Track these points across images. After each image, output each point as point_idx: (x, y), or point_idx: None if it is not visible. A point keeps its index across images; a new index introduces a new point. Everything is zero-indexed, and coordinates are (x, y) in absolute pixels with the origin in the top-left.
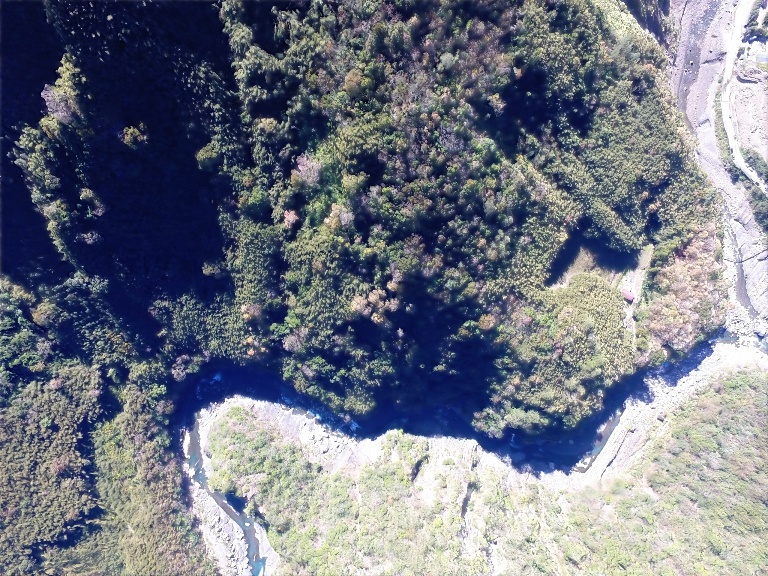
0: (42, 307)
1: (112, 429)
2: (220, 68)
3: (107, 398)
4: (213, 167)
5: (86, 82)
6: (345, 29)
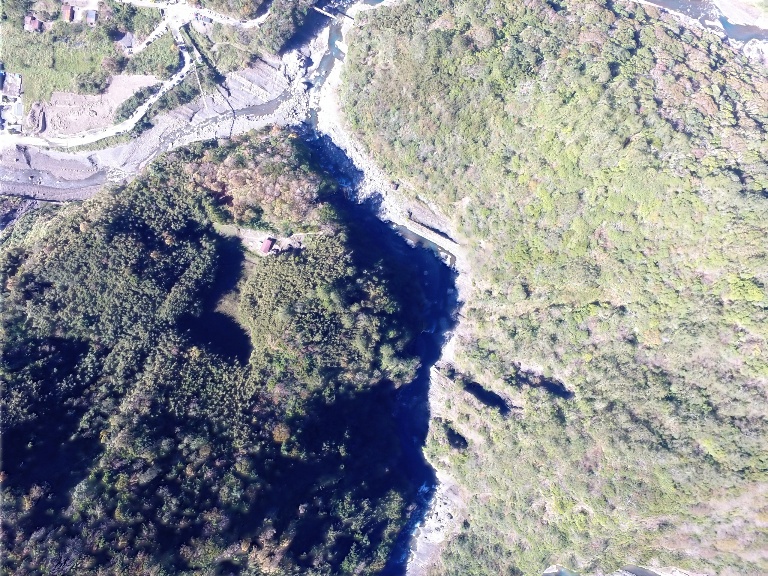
0: None
1: None
2: None
3: None
4: None
5: None
6: None
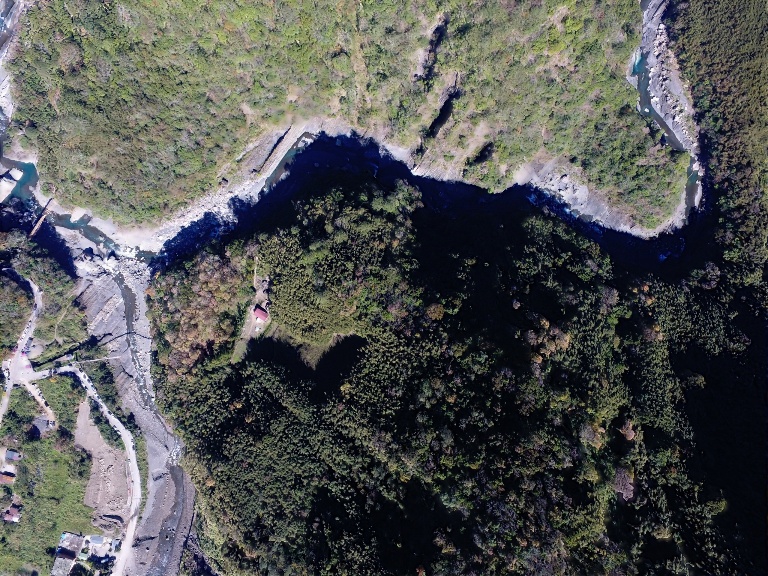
0: None
1: None
2: None
3: None
4: (707, 490)
5: None
6: None
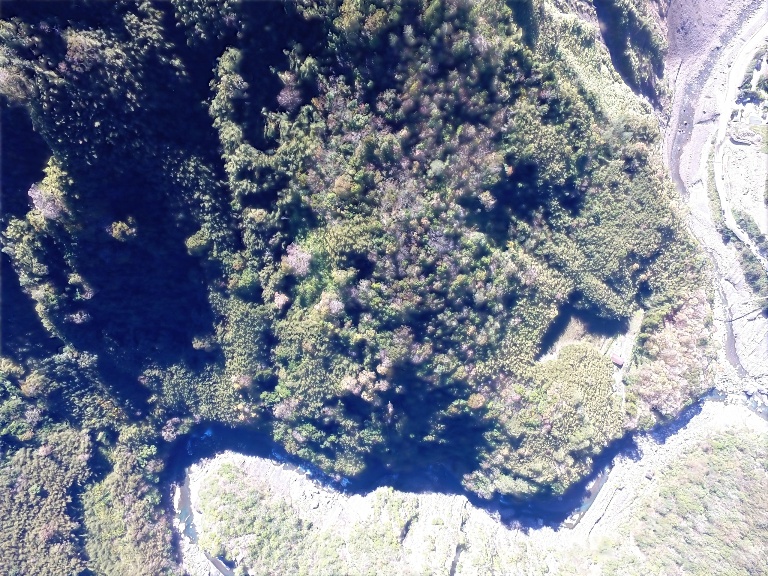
0: (31, 379)
1: (102, 490)
2: (210, 160)
3: (97, 459)
4: (203, 252)
5: (73, 184)
6: (335, 137)
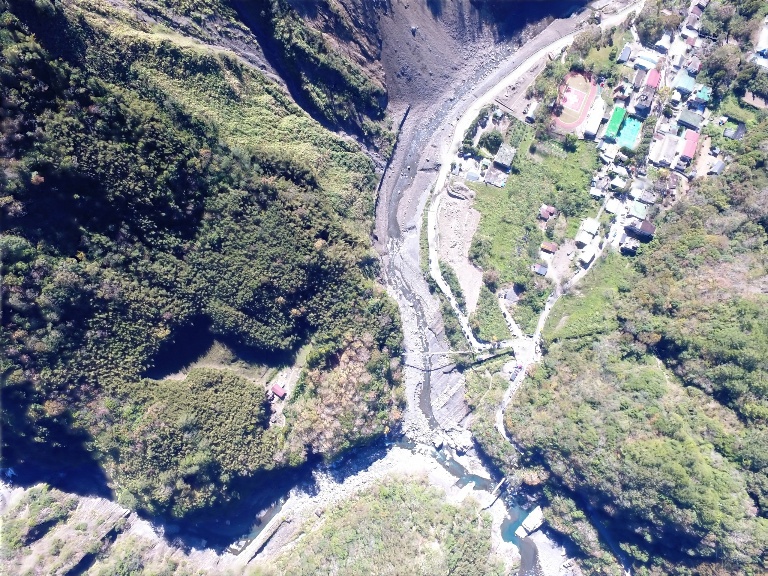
0: None
1: None
2: None
3: None
4: None
5: None
6: None
